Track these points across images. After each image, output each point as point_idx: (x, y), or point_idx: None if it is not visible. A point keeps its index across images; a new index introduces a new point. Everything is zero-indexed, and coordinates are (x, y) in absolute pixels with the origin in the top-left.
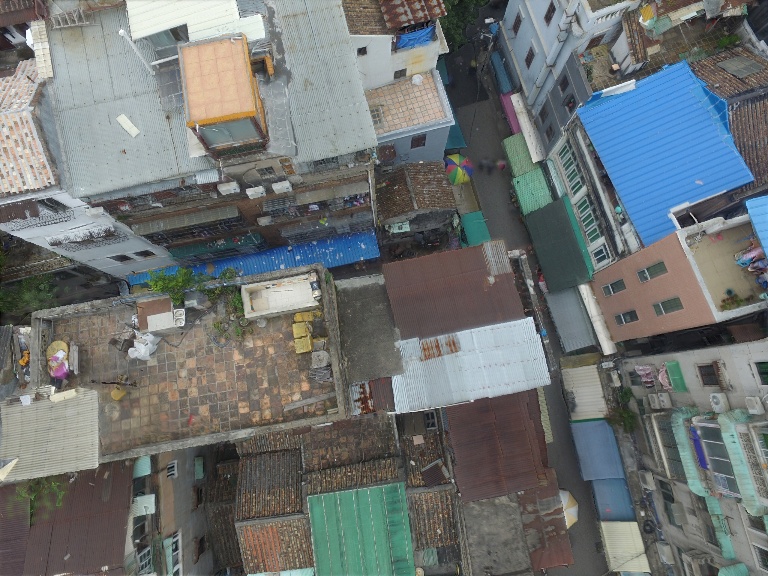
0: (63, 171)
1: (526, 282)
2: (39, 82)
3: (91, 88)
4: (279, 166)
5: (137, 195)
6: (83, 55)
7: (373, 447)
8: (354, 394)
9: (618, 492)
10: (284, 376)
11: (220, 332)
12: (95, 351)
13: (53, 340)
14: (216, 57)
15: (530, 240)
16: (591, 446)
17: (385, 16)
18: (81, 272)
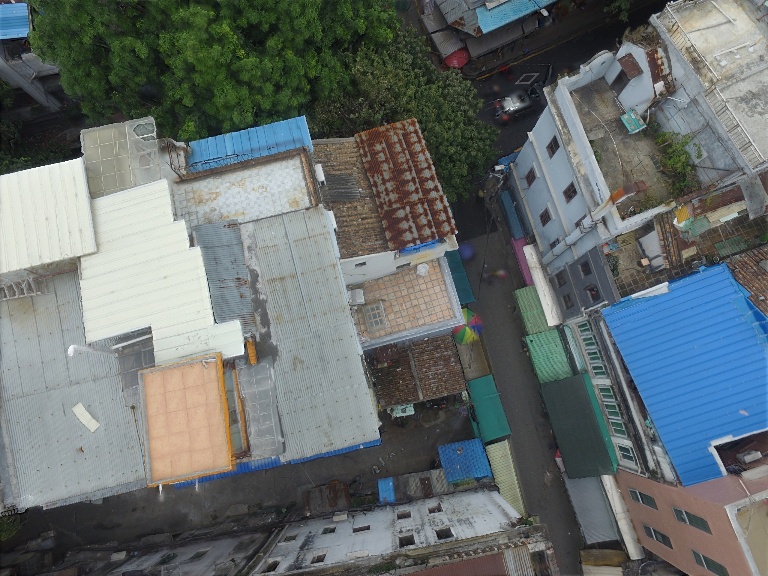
0: (8, 477)
1: None
2: None
3: (42, 371)
4: None
5: None
6: (33, 330)
7: None
8: None
9: None
10: None
11: None
12: None
13: None
14: (184, 386)
15: (546, 412)
16: None
17: (387, 233)
18: None
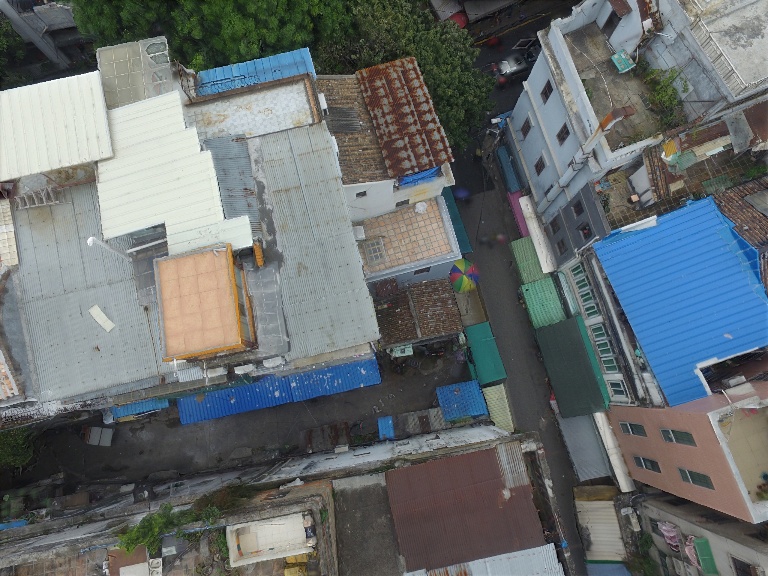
0: (29, 373)
1: (544, 481)
2: (2, 273)
3: (61, 275)
4: None
5: (112, 395)
6: (52, 237)
7: None
8: None
9: None
10: None
11: None
12: None
13: None
14: (197, 272)
15: (541, 356)
16: None
17: (386, 161)
18: None
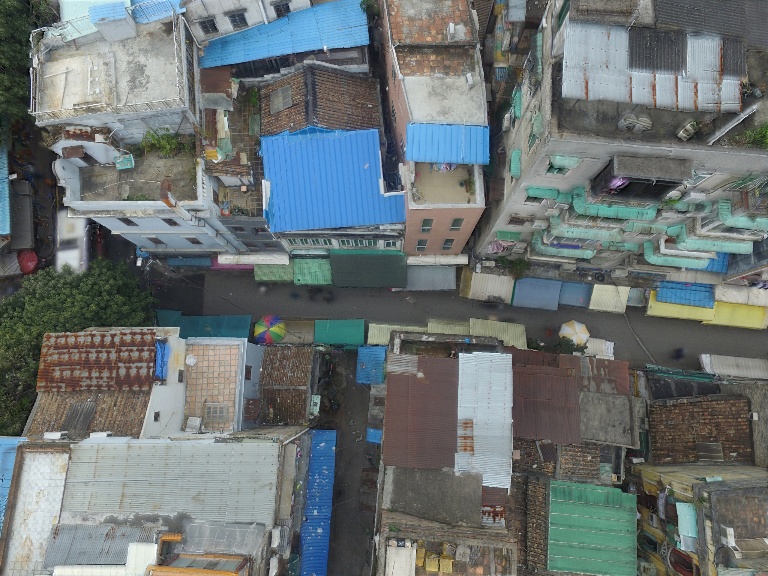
0: None
1: None
2: None
3: None
4: None
5: None
6: None
7: (515, 497)
8: (489, 522)
9: (570, 289)
10: None
11: None
12: None
13: None
14: None
15: None
16: (533, 297)
17: (134, 388)
18: None
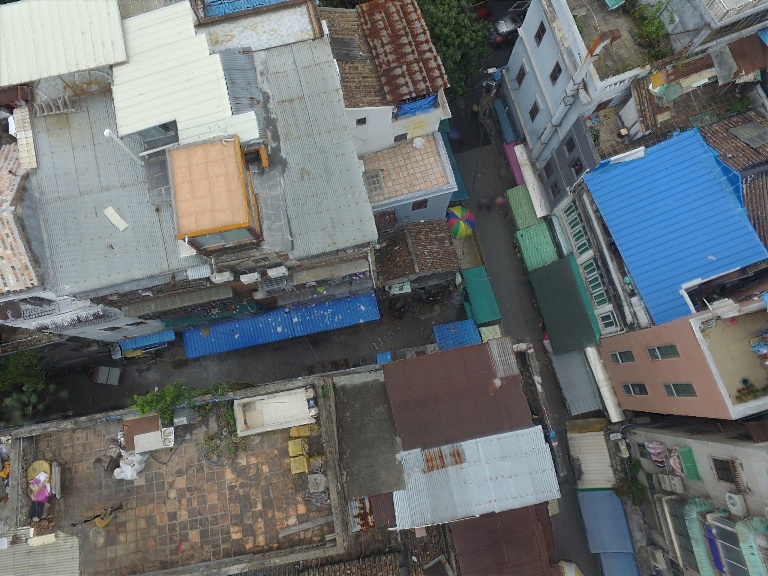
0: (47, 268)
1: (533, 378)
2: (22, 174)
3: (77, 179)
4: (274, 256)
5: (125, 291)
6: (68, 143)
7: (373, 540)
8: (353, 510)
9: (626, 566)
10: (279, 497)
11: (211, 449)
12: (79, 469)
13: (35, 457)
14: (207, 161)
15: (534, 297)
16: (598, 517)
17: (385, 87)
18: (71, 340)
